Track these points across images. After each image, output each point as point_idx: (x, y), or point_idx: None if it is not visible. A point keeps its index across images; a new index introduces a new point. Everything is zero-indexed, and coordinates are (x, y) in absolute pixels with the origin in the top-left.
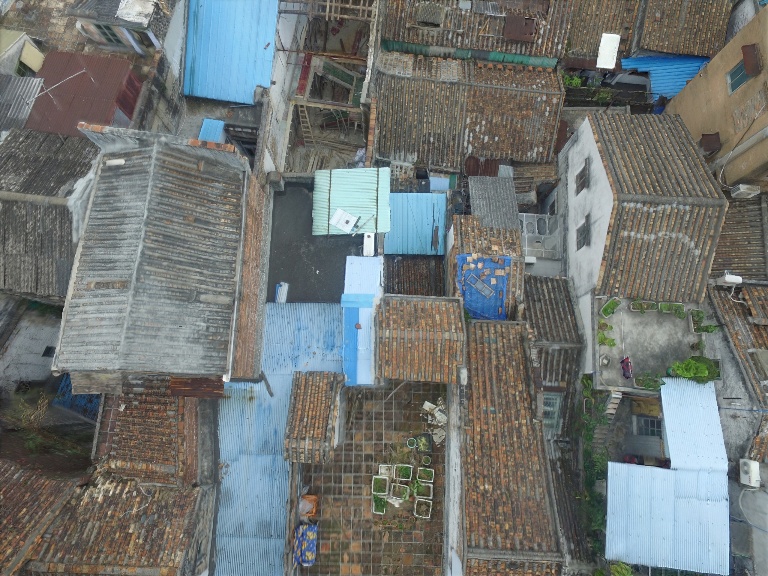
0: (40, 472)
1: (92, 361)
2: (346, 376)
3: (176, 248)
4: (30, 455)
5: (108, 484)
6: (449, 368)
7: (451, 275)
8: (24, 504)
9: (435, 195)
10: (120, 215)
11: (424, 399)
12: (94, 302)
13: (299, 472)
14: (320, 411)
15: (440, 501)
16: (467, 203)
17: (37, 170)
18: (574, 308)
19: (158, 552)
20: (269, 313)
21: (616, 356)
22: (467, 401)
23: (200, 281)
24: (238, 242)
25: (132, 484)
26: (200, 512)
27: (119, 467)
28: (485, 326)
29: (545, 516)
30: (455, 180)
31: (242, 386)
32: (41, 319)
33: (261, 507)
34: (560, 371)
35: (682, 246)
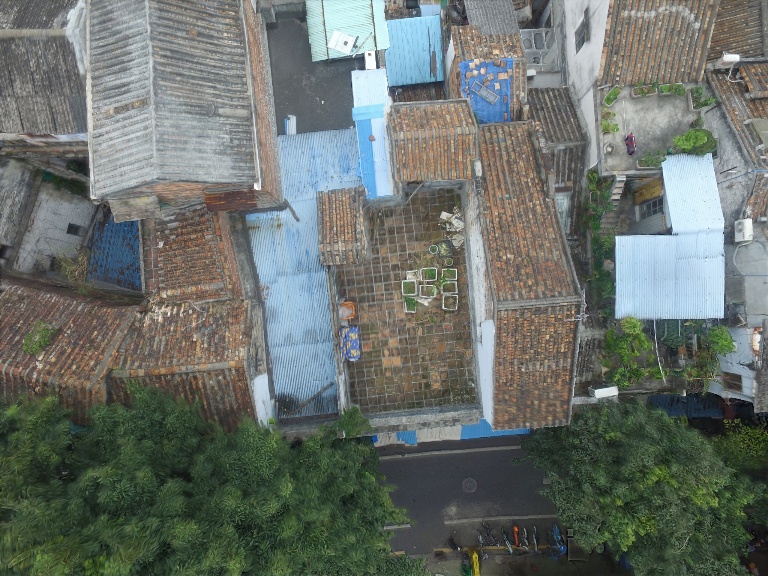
0: (100, 304)
1: (129, 179)
2: (366, 189)
3: (186, 63)
4: (85, 298)
5: (164, 308)
6: (464, 163)
7: (454, 90)
8: (94, 328)
9: (429, 18)
10: (122, 37)
11: (441, 210)
12: (117, 127)
13: (334, 284)
14: (347, 220)
15: (465, 296)
16: (463, 15)
17: (25, 6)
18: (576, 111)
19: (223, 352)
20: (282, 145)
21: (619, 143)
22: (483, 190)
23: (215, 95)
24: (244, 56)
25: (186, 305)
26: (252, 320)
27: (170, 295)
28: (493, 128)
29: (563, 271)
30: (446, 5)
31: (269, 215)
32: (58, 193)
33: (305, 318)
34: (566, 171)
35: (682, 21)
